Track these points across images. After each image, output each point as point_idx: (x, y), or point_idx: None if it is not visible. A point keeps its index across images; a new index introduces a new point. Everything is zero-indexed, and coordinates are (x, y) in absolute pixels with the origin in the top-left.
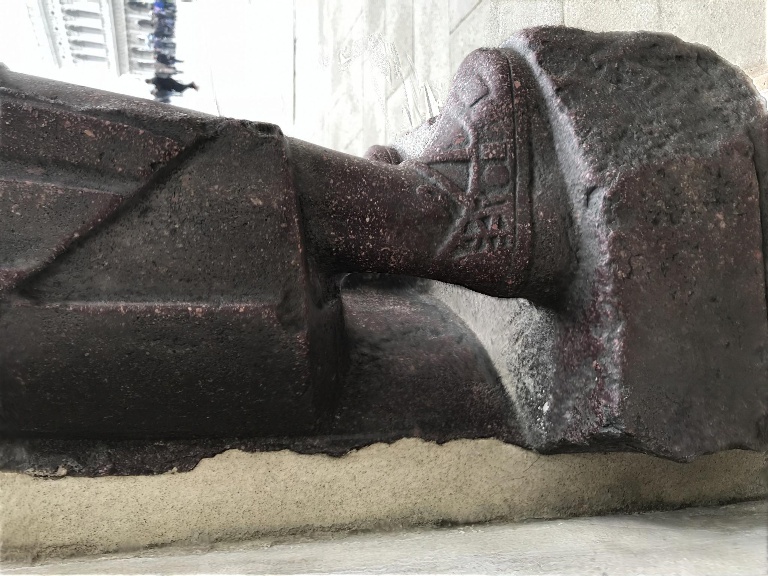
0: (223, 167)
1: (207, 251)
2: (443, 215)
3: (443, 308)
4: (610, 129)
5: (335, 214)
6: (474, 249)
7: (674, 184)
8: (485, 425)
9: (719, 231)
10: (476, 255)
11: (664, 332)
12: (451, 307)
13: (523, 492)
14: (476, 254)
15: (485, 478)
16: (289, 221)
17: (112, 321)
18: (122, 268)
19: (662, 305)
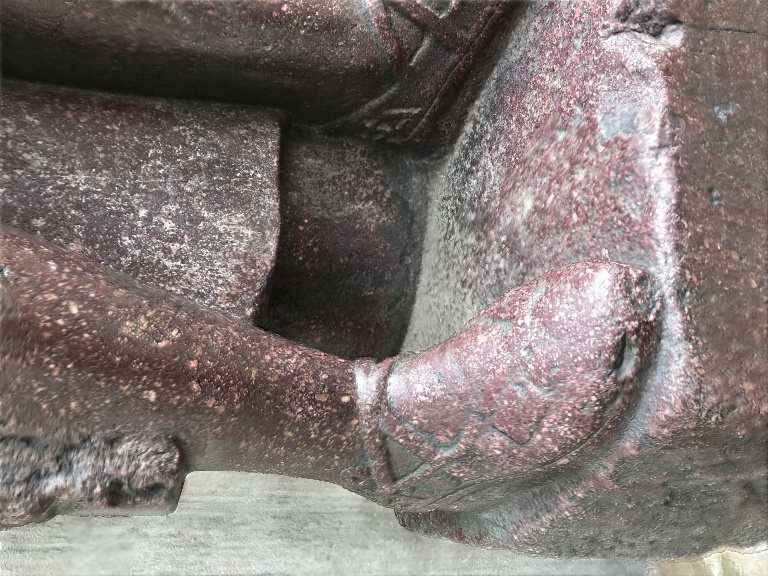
0: None
1: None
2: None
3: (418, 228)
4: (585, 535)
5: None
6: None
7: None
8: None
9: None
10: None
11: None
12: (427, 233)
13: None
14: None
15: None
16: None
17: None
18: None
19: None
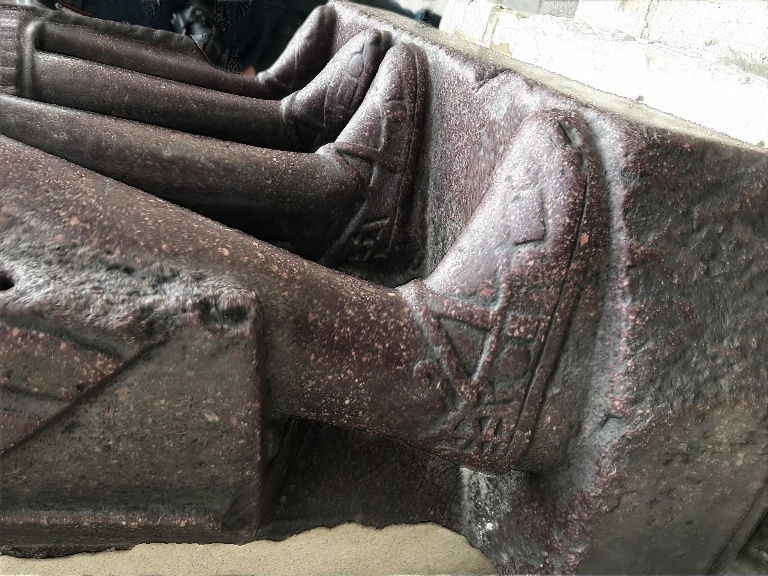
0: (173, 378)
1: (147, 467)
2: (437, 406)
3: None
4: (669, 348)
5: (310, 394)
6: (460, 448)
7: (709, 428)
8: (428, 511)
9: (732, 468)
10: (460, 453)
11: (625, 552)
12: None
13: (447, 560)
14: (461, 452)
15: (415, 553)
16: (249, 436)
17: (35, 528)
18: (44, 482)
19: (635, 531)
